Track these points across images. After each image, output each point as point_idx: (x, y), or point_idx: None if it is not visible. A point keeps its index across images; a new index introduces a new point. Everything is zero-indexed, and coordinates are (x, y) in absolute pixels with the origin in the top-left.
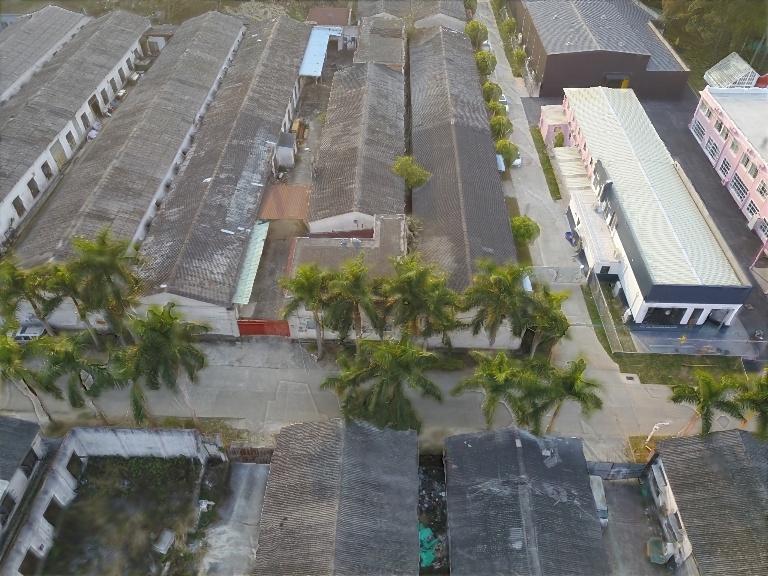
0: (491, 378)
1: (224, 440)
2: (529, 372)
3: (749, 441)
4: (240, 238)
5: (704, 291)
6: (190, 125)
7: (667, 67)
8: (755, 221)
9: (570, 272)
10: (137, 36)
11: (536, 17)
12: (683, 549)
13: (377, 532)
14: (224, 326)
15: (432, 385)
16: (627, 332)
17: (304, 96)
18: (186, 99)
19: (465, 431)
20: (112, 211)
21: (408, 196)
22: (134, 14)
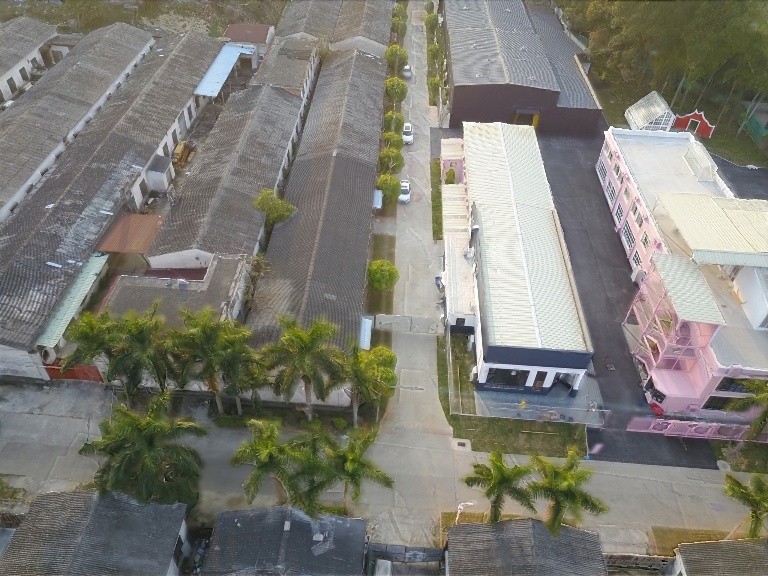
0: (253, 455)
1: None
2: (309, 446)
3: (541, 533)
4: (67, 272)
5: (543, 354)
6: (57, 144)
7: (580, 104)
8: (636, 273)
9: (424, 322)
10: (36, 45)
11: (455, 45)
12: None
13: None
14: (30, 369)
15: (185, 461)
16: (471, 391)
17: (202, 116)
18: (61, 116)
19: (265, 499)
20: None
21: (269, 232)
22: (45, 21)
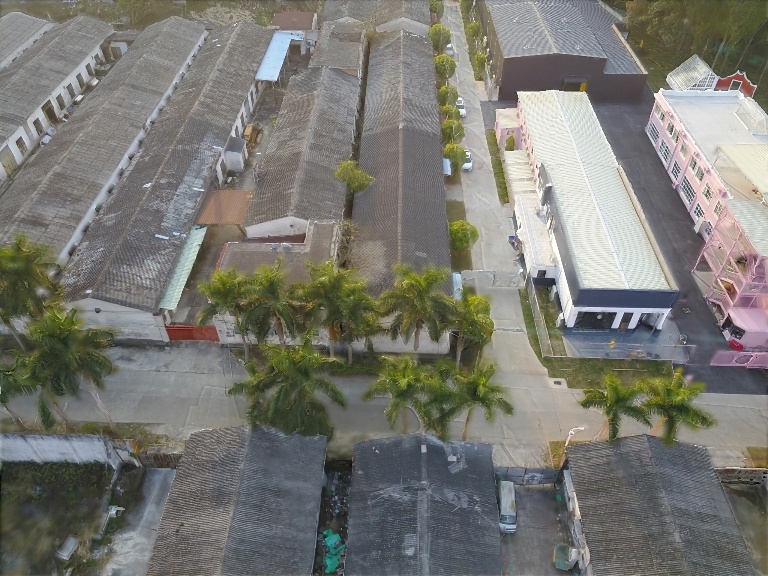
0: (393, 384)
1: (135, 446)
2: (437, 377)
3: (656, 446)
4: (174, 243)
5: (631, 295)
6: (139, 130)
7: (626, 70)
8: (700, 224)
9: (507, 276)
10: (98, 42)
11: (497, 20)
12: (585, 555)
13: (271, 538)
14: (153, 331)
15: (333, 391)
16: (559, 336)
17: (262, 101)
18: (137, 104)
19: None
20: (48, 217)
21: (350, 200)
22: (99, 20)
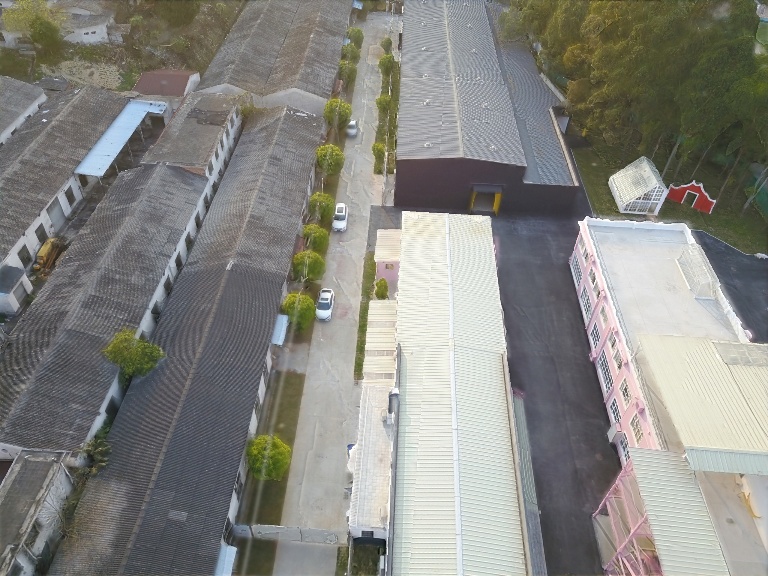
0: None
1: None
2: None
3: None
4: None
5: None
6: None
7: (552, 177)
8: (614, 434)
9: (318, 533)
10: None
11: (404, 101)
12: None
13: None
14: None
15: None
16: None
17: (90, 196)
18: None
19: None
20: None
21: (123, 390)
22: None
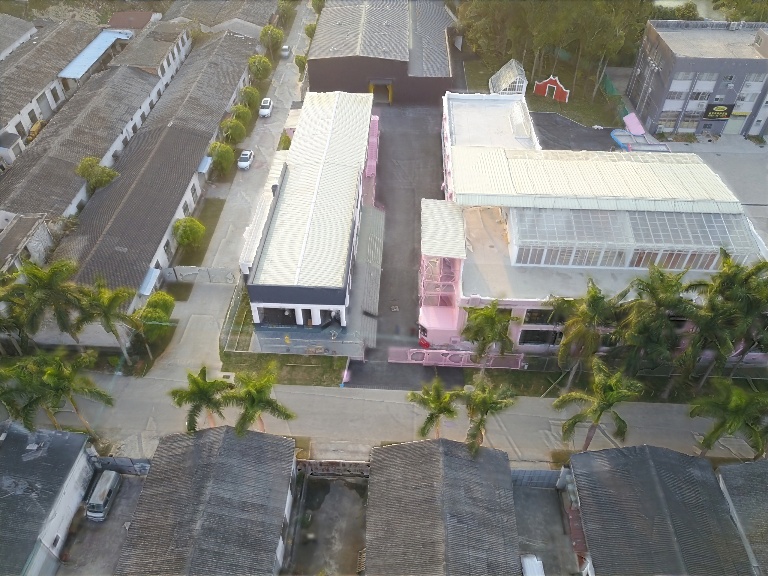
0: None
1: None
2: None
3: (233, 437)
4: None
5: (299, 291)
6: None
7: (433, 73)
8: None
9: (220, 272)
10: None
11: (322, 23)
12: None
13: None
14: None
15: None
16: (250, 332)
17: None
18: None
19: None
20: None
21: (89, 196)
22: None
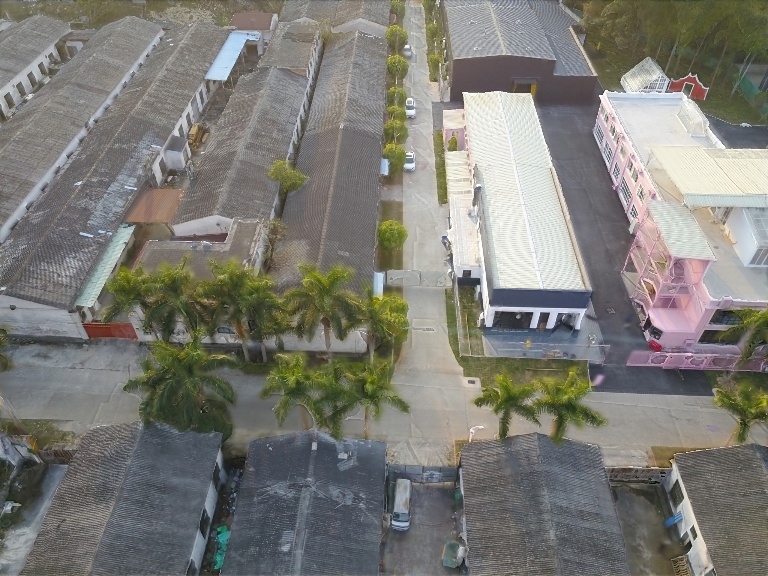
0: (282, 381)
1: (32, 442)
2: (331, 375)
3: (546, 445)
4: (98, 241)
5: (545, 295)
6: (80, 129)
7: (576, 72)
8: (634, 225)
9: (433, 276)
10: (53, 41)
11: (452, 22)
12: None
13: (150, 534)
14: (70, 329)
15: (221, 388)
16: (479, 336)
17: (213, 100)
18: (81, 103)
19: None
20: None
21: (283, 200)
22: (59, 19)
